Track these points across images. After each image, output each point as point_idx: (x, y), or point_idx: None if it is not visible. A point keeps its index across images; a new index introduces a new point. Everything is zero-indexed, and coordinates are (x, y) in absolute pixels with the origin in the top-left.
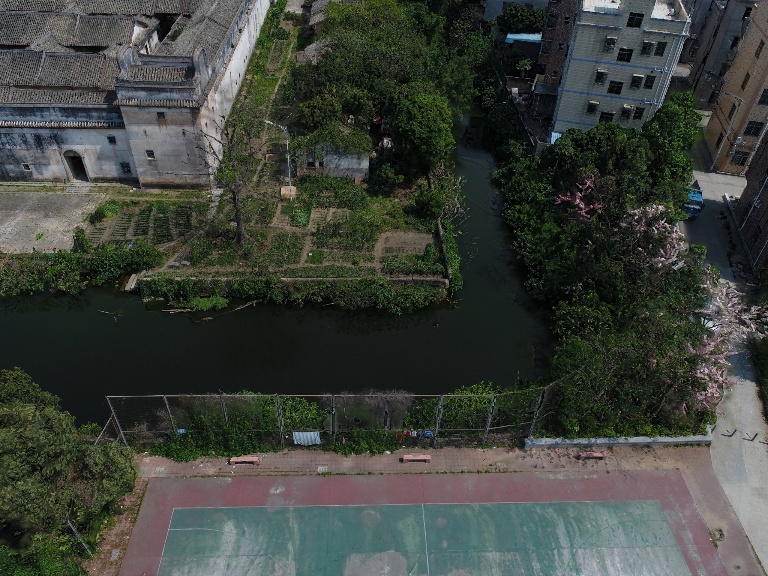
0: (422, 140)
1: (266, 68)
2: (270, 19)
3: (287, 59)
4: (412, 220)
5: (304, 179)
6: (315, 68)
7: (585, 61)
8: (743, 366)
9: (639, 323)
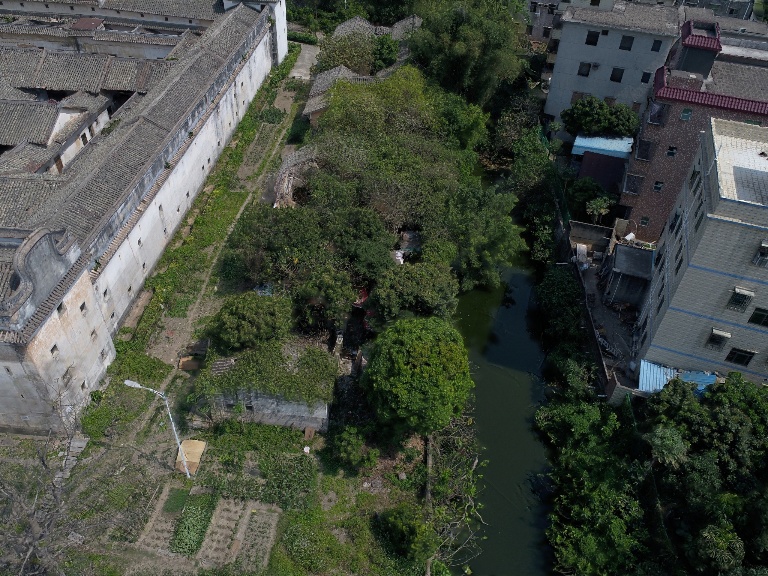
0: (410, 410)
1: (234, 176)
2: (266, 89)
3: (270, 157)
4: (381, 558)
5: (220, 429)
6: (275, 215)
7: (713, 272)
8: None
9: None
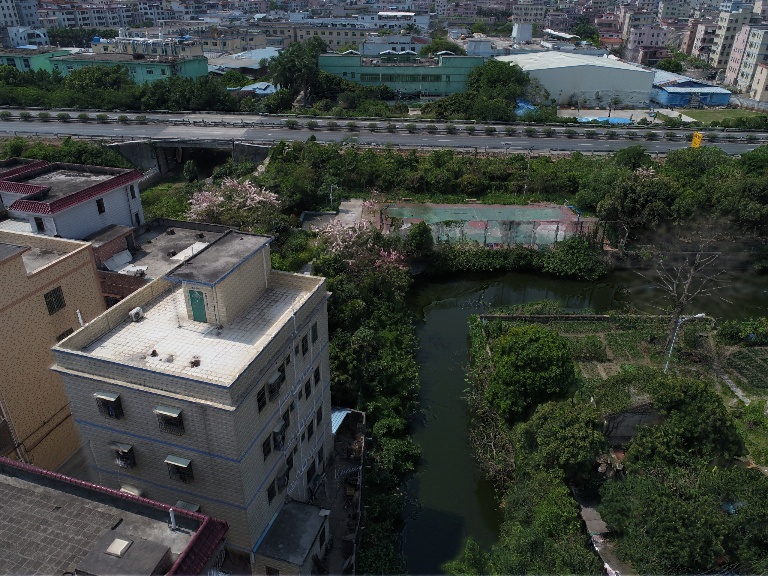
0: None
1: None
2: None
3: None
4: None
5: None
6: None
7: None
8: (308, 268)
9: (379, 241)
